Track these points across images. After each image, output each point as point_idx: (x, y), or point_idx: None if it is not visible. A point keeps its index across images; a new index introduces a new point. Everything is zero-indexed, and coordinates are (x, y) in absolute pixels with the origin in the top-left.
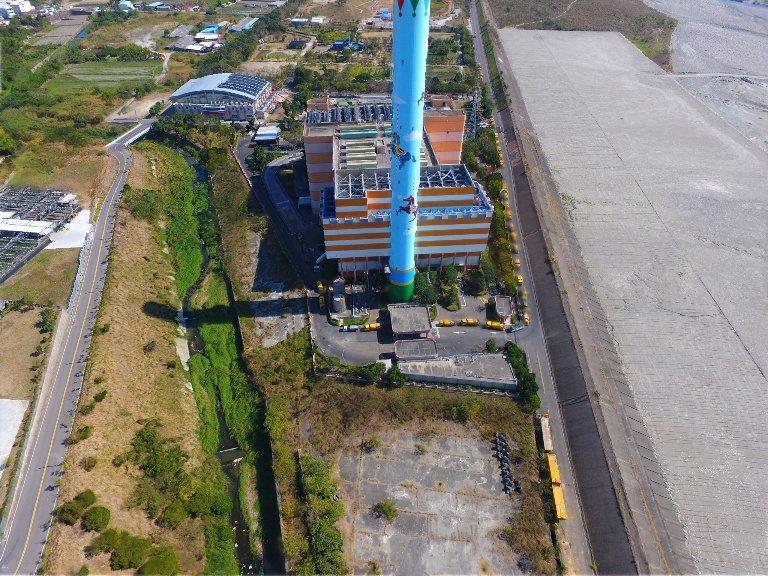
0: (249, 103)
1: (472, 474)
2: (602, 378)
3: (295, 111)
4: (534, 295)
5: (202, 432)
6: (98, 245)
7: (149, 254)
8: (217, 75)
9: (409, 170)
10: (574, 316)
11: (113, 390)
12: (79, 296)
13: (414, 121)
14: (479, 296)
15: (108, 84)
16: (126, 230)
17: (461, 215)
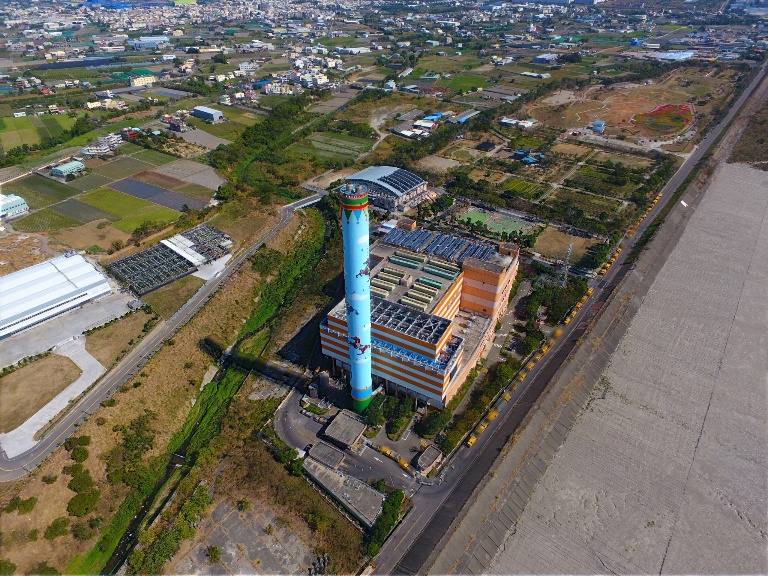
0: (395, 197)
1: (283, 571)
2: (449, 568)
3: (426, 213)
4: (472, 462)
5: (176, 436)
6: (216, 283)
7: (242, 299)
8: (388, 168)
9: (353, 318)
10: (477, 500)
11: (147, 384)
12: (180, 314)
13: (354, 287)
14: (423, 438)
15: (327, 154)
16: (240, 277)
17: (418, 364)
